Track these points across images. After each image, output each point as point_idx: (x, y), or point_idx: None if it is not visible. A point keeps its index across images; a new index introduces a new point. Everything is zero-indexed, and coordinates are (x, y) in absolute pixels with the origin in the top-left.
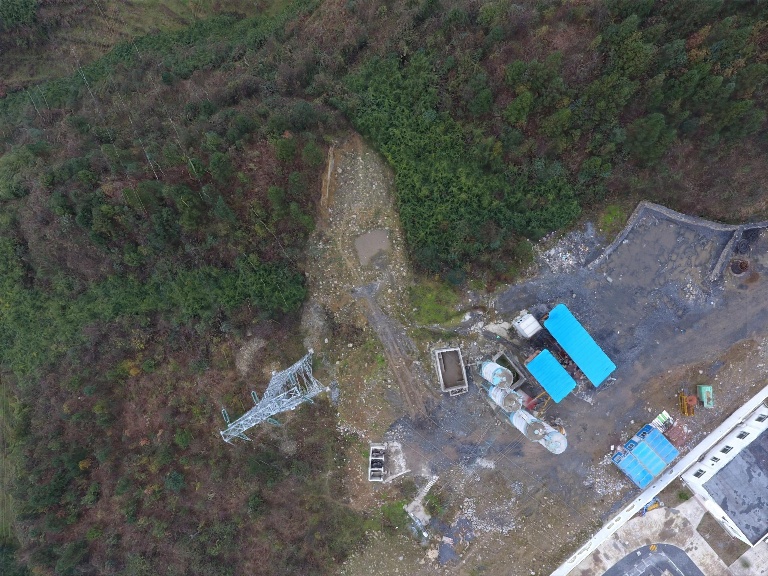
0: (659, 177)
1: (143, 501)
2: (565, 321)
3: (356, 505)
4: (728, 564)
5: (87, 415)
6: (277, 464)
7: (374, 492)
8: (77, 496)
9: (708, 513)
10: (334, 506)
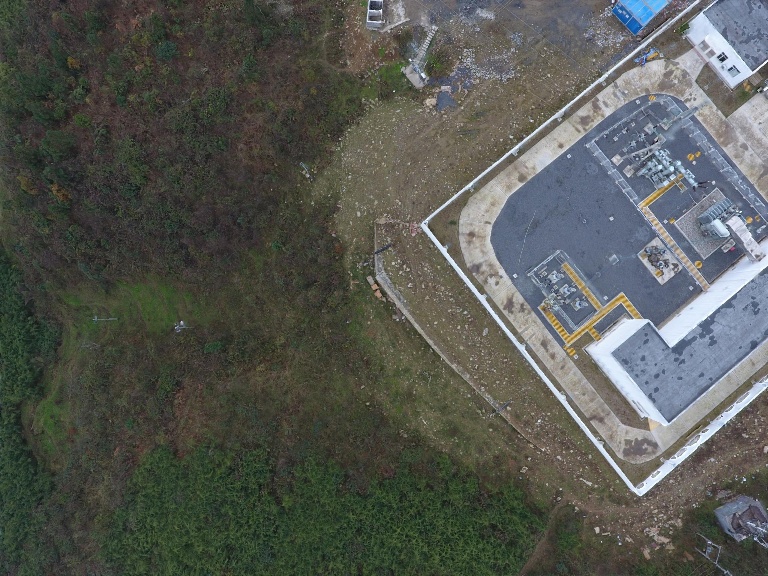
0: None
1: (134, 78)
2: None
3: (353, 66)
4: (726, 115)
5: (77, 23)
6: (273, 16)
7: (372, 43)
8: (65, 88)
9: (707, 65)
10: (331, 71)
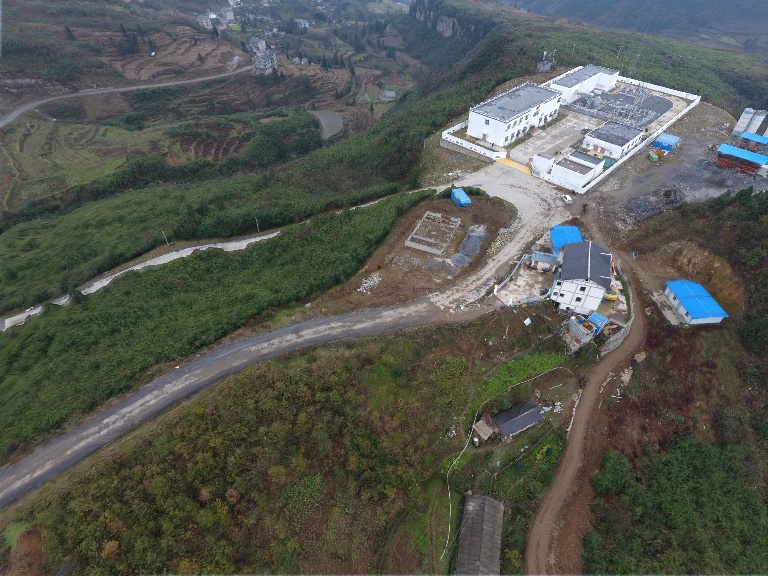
0: None
1: None
2: (757, 159)
3: None
4: None
5: None
6: None
7: None
8: None
9: None
10: None
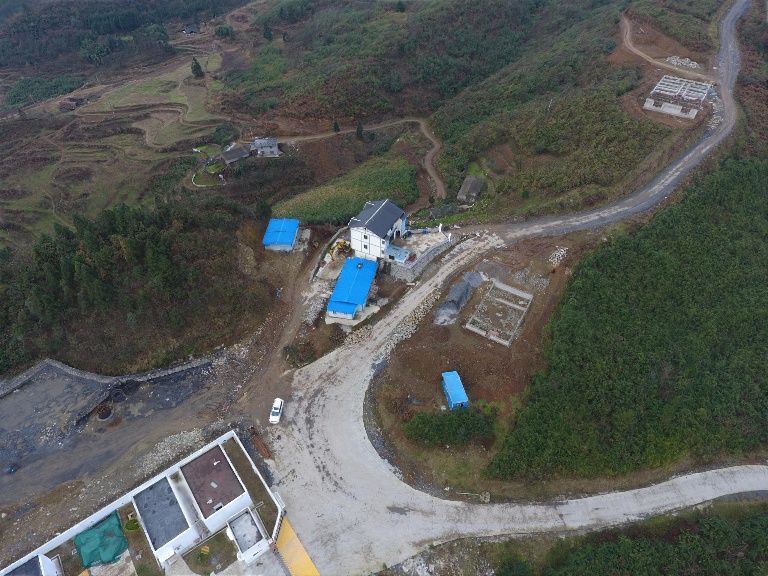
0: (53, 336)
1: None
2: None
3: None
4: None
5: None
6: None
7: None
8: None
9: None
10: None
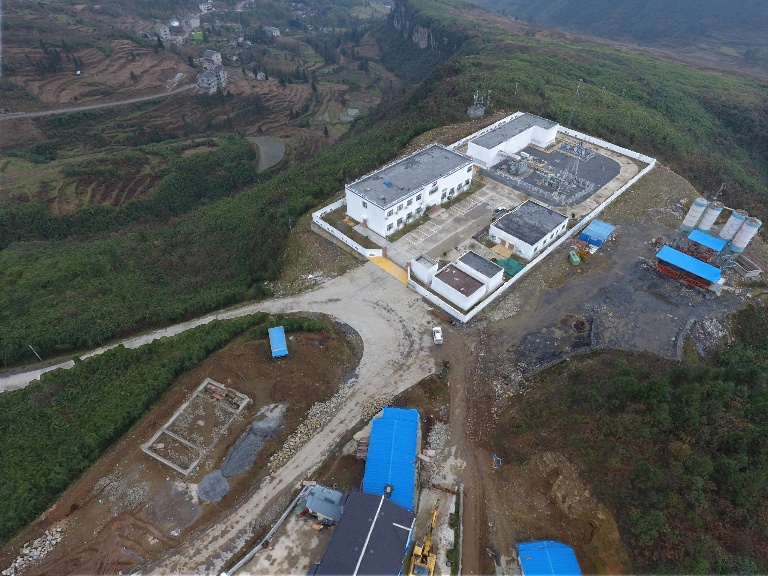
0: None
1: None
2: (707, 274)
3: None
4: None
5: None
6: None
7: None
8: None
9: None
10: None
